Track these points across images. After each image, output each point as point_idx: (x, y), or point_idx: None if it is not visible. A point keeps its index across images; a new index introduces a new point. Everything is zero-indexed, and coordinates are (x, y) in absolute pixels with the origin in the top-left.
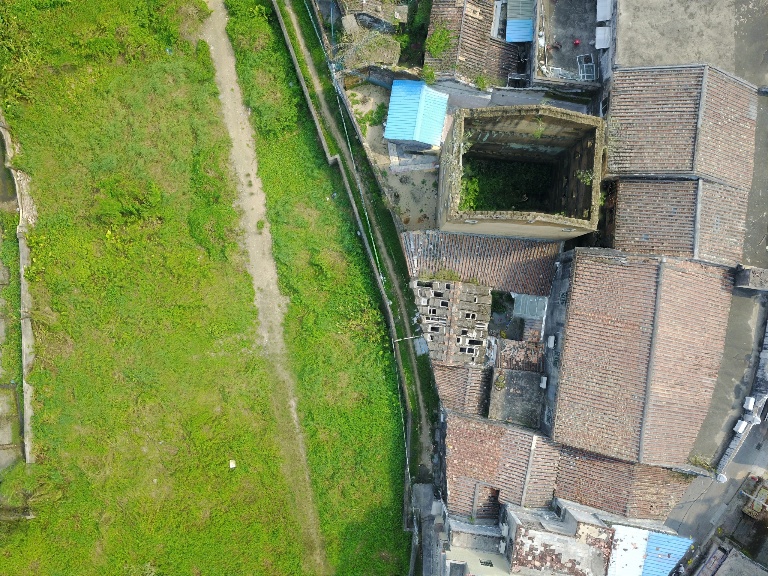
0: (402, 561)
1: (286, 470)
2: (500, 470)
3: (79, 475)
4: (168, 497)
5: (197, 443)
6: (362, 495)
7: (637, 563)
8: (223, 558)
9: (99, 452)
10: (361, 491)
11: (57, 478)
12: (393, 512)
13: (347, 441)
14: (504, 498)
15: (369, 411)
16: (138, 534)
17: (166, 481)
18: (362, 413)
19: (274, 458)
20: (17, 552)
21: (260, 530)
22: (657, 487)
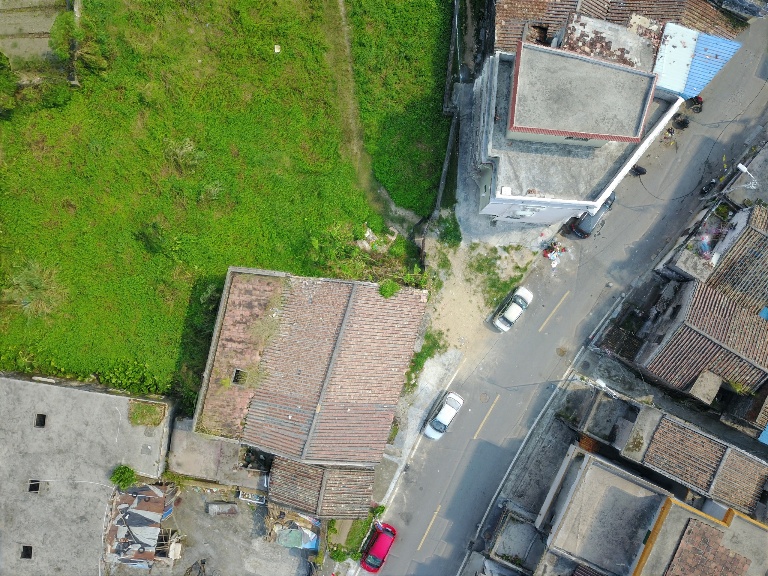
0: (438, 152)
1: (330, 59)
2: (550, 6)
3: (125, 51)
4: (212, 76)
5: (244, 23)
6: (404, 85)
7: (685, 61)
8: (262, 139)
9: (146, 30)
10: (403, 80)
11: (104, 44)
12: (433, 103)
13: (393, 32)
14: (553, 31)
15: (416, 4)
16: (180, 110)
17: (211, 60)
18: (409, 6)
19: (319, 44)
20: (59, 116)
21: (300, 114)
22: (705, 25)
